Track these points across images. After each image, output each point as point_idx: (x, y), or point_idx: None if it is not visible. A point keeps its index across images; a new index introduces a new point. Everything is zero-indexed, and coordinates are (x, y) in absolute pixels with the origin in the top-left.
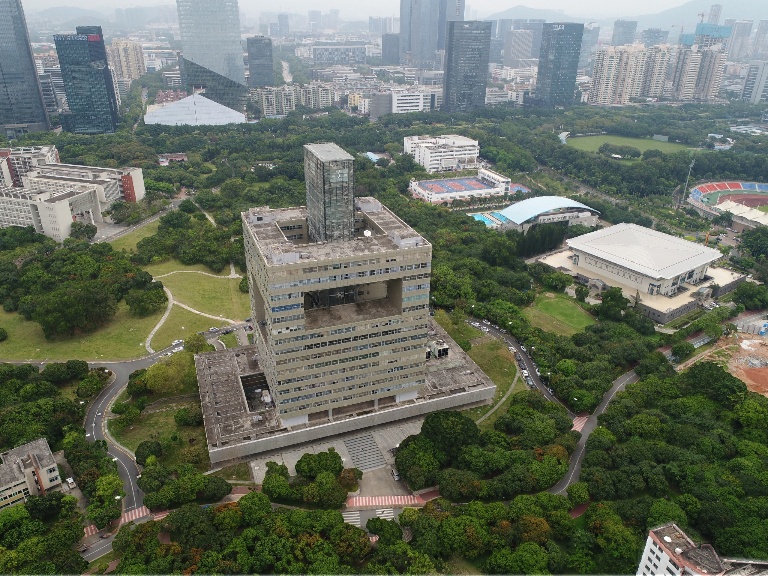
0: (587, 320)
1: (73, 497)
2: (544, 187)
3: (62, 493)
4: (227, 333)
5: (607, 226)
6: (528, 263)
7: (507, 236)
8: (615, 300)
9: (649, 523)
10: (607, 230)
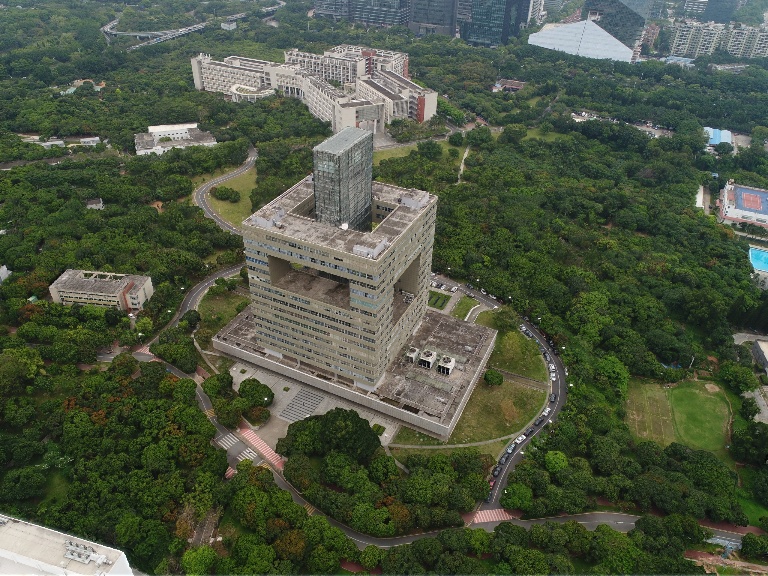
0: (712, 440)
1: (129, 320)
2: None
3: (126, 314)
4: None
5: None
6: (754, 340)
7: (763, 295)
8: (761, 439)
9: None
10: None
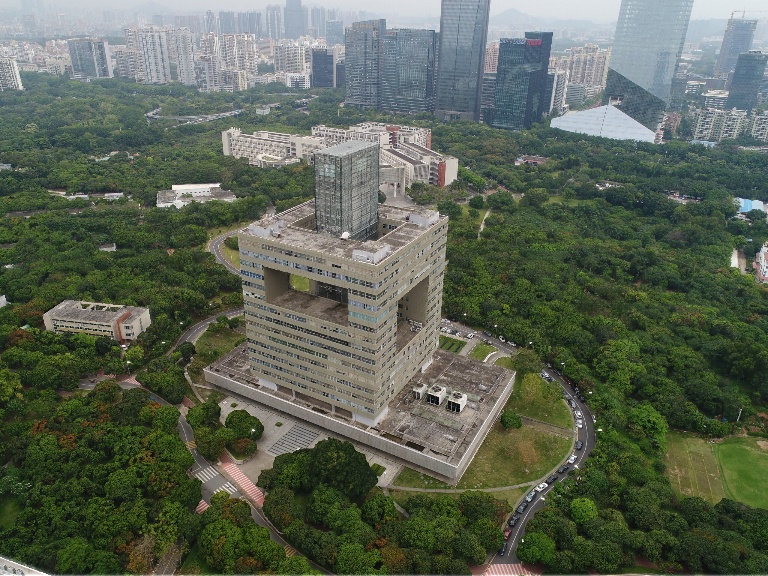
0: None
1: (119, 349)
2: None
3: (118, 343)
4: None
5: None
6: None
7: None
8: None
9: None
10: None
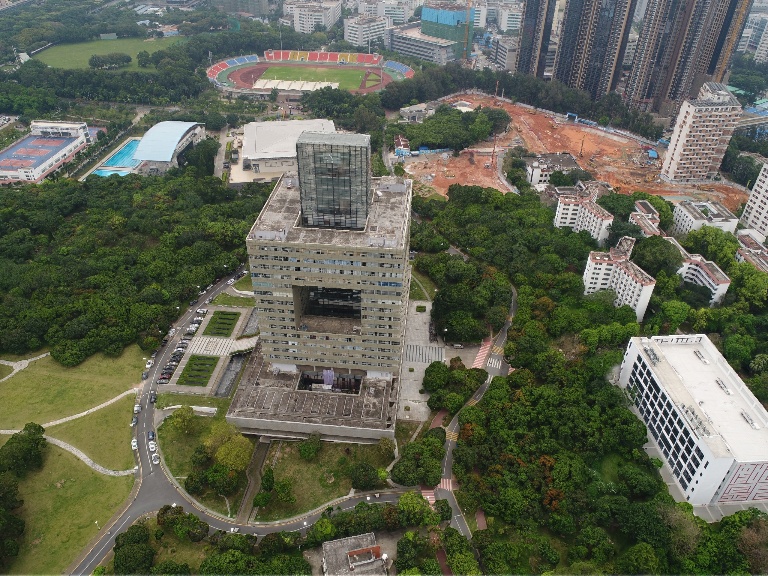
0: None
1: None
2: (102, 120)
3: None
4: (155, 399)
5: (208, 134)
6: None
7: None
8: None
9: (557, 267)
10: (248, 135)
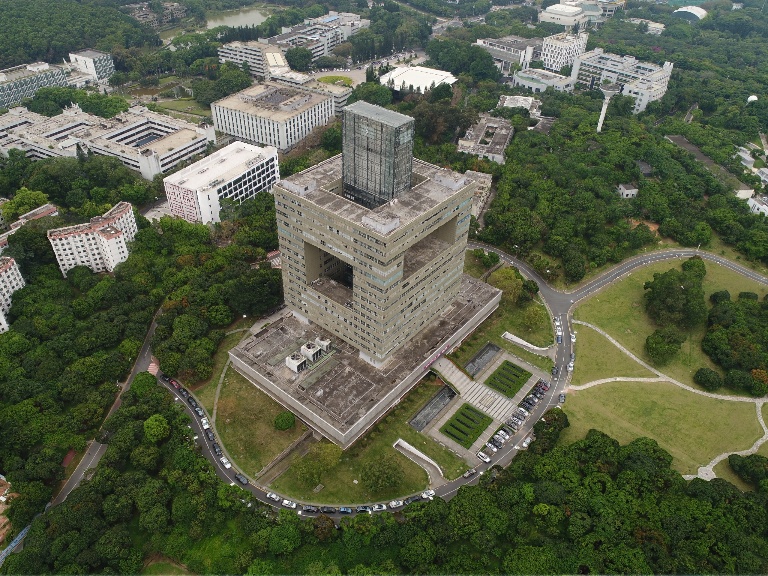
0: None
1: None
2: None
3: None
4: None
5: None
6: None
7: None
8: None
9: None
10: None
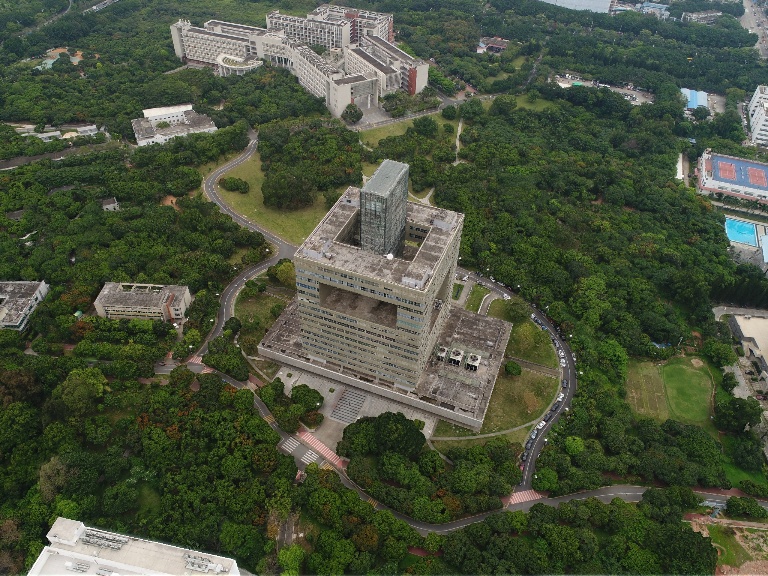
0: (699, 412)
1: (176, 332)
2: None
3: (173, 326)
4: None
5: None
6: (730, 312)
7: (738, 269)
8: (741, 412)
9: None
10: None
